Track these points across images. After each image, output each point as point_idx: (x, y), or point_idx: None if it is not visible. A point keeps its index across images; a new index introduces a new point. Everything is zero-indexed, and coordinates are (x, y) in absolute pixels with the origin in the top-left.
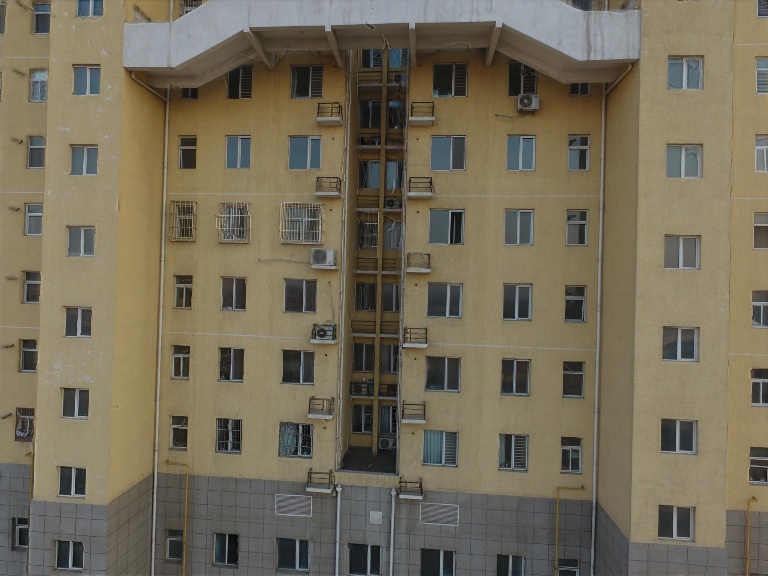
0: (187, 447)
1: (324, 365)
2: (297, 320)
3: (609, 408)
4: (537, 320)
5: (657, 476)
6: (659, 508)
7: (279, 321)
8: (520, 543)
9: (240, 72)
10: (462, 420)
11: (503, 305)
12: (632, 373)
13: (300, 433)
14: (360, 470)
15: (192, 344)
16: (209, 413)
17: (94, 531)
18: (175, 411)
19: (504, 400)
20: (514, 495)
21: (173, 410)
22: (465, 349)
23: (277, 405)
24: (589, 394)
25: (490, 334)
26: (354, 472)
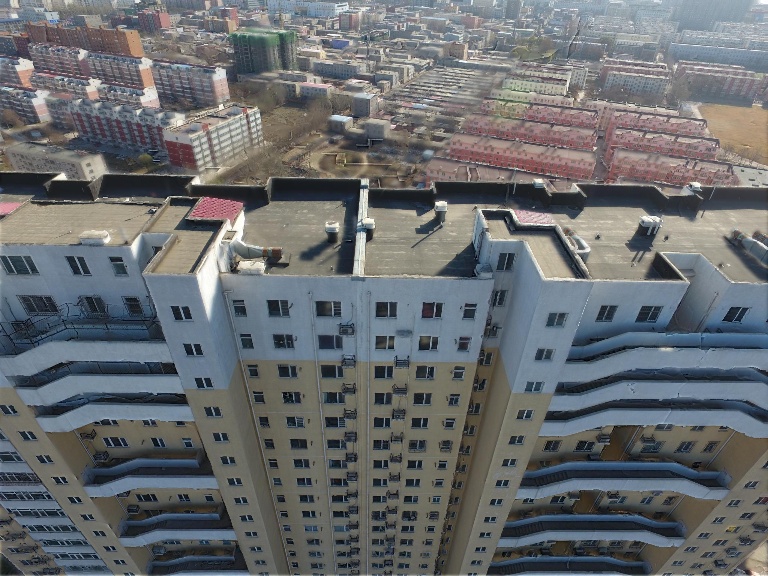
0: None
1: None
2: None
3: None
4: None
5: None
6: None
7: None
8: None
9: (507, 552)
10: None
11: None
12: None
13: None
14: None
15: None
16: None
17: None
18: None
19: None
20: None
21: None
22: None
23: None
24: None
25: None
26: None
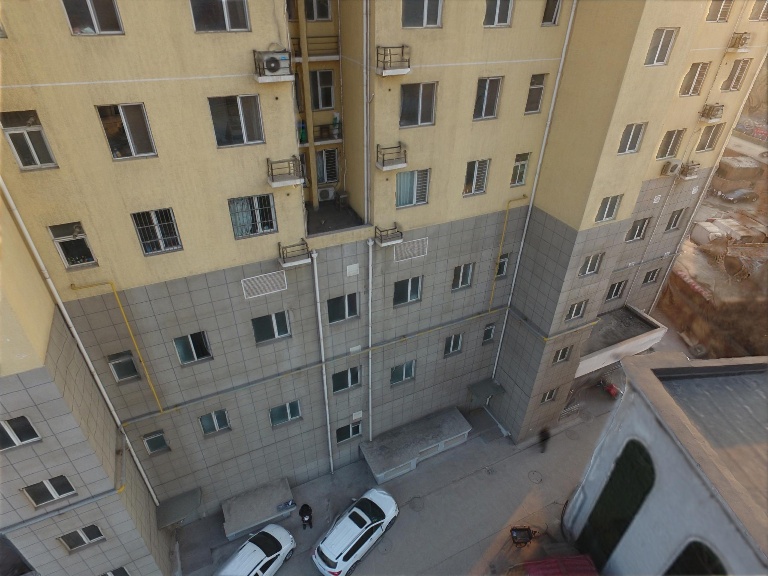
0: (96, 261)
1: (276, 113)
2: (223, 46)
3: (568, 120)
4: (517, 26)
5: (609, 176)
6: (602, 201)
7: (193, 49)
8: (473, 253)
9: None
10: (435, 155)
11: (486, 6)
12: (620, 83)
13: (256, 207)
14: (331, 230)
15: (38, 106)
16: (116, 210)
17: (38, 399)
18: (54, 219)
19: (475, 126)
20: (473, 216)
21: (49, 218)
22: (443, 70)
23: (219, 179)
24: (546, 108)
25: (470, 48)
26: (327, 234)
